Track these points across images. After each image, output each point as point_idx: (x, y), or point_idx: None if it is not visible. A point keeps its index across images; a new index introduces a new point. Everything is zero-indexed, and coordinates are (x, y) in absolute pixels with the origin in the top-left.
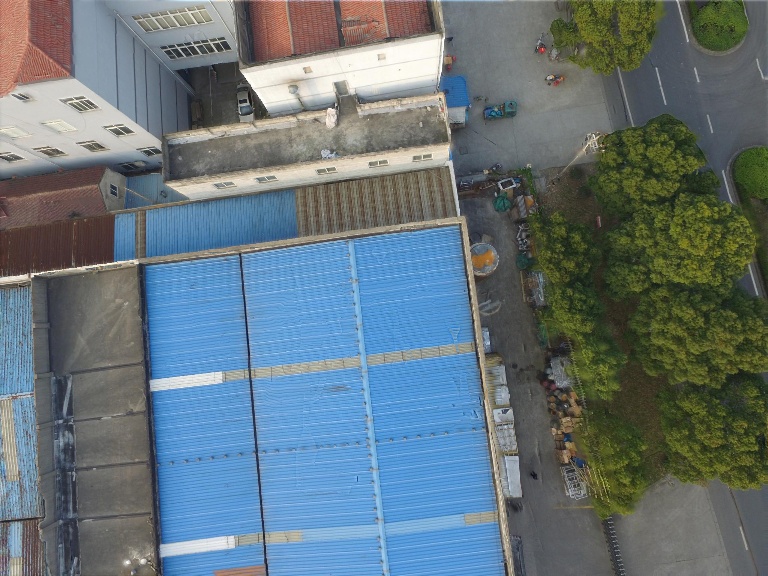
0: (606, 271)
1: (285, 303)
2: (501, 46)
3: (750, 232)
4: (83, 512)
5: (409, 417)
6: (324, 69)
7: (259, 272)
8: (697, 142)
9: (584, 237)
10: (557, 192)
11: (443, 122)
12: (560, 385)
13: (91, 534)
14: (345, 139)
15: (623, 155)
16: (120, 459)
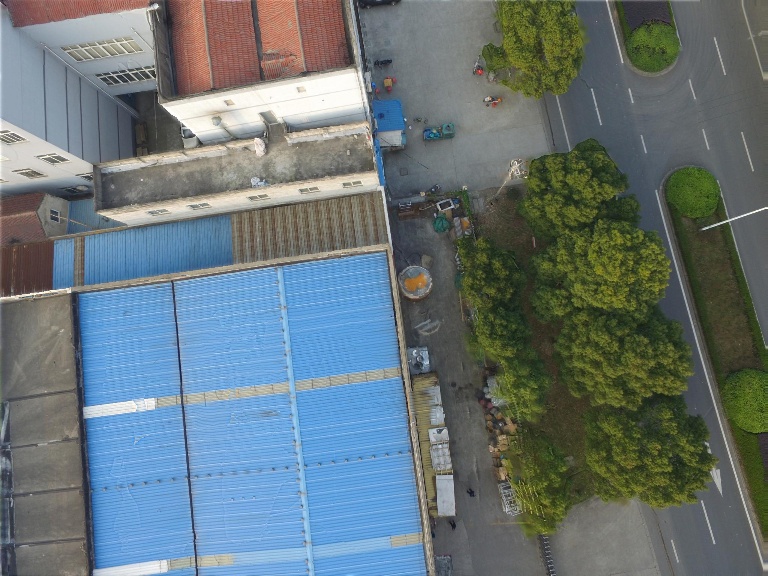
0: (532, 294)
1: (217, 329)
2: (440, 68)
3: (661, 259)
4: (20, 538)
5: (237, 479)
6: (246, 101)
7: (191, 299)
8: (631, 162)
9: (505, 263)
10: (495, 212)
11: (370, 150)
12: (496, 404)
13: (28, 559)
14: (274, 167)
15: (547, 181)
16: (56, 485)
